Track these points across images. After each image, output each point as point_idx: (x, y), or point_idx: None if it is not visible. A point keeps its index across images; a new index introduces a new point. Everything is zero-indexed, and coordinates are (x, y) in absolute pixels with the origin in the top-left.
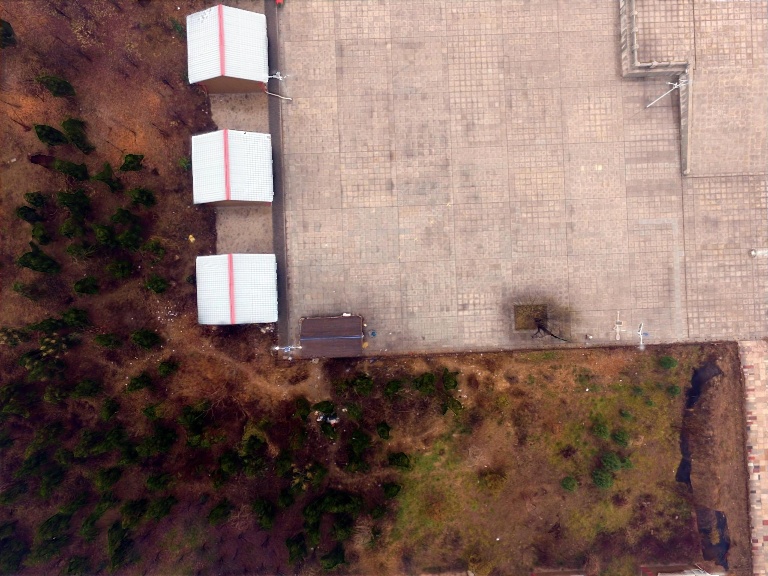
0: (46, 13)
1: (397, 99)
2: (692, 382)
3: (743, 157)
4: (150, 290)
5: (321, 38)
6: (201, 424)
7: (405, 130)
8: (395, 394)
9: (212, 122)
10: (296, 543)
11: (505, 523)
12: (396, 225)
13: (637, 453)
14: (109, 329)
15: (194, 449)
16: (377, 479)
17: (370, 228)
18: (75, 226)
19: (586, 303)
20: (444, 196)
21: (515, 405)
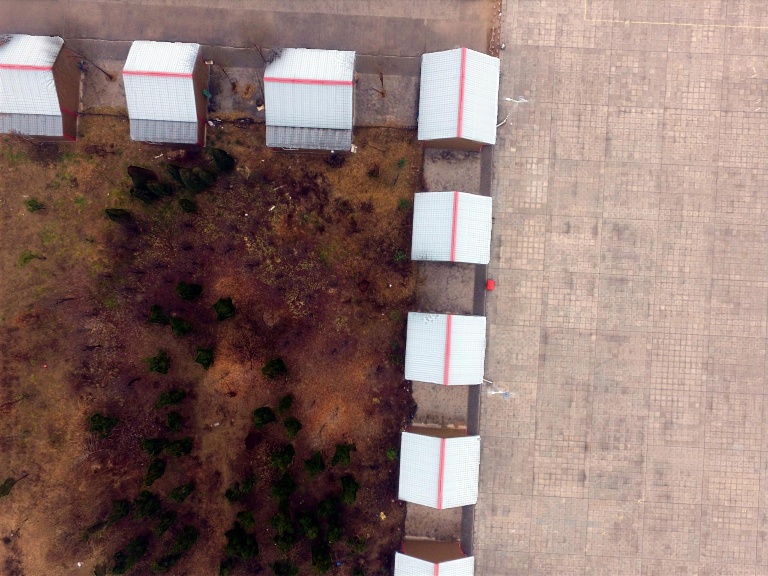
0: (262, 282)
1: (597, 391)
2: None
3: None
4: (339, 566)
5: (527, 324)
6: None
7: (602, 422)
8: None
9: (412, 399)
10: None
11: None
12: (585, 517)
13: None
14: None
15: None
16: None
17: (559, 518)
18: (287, 523)
19: None
20: (636, 492)
21: None
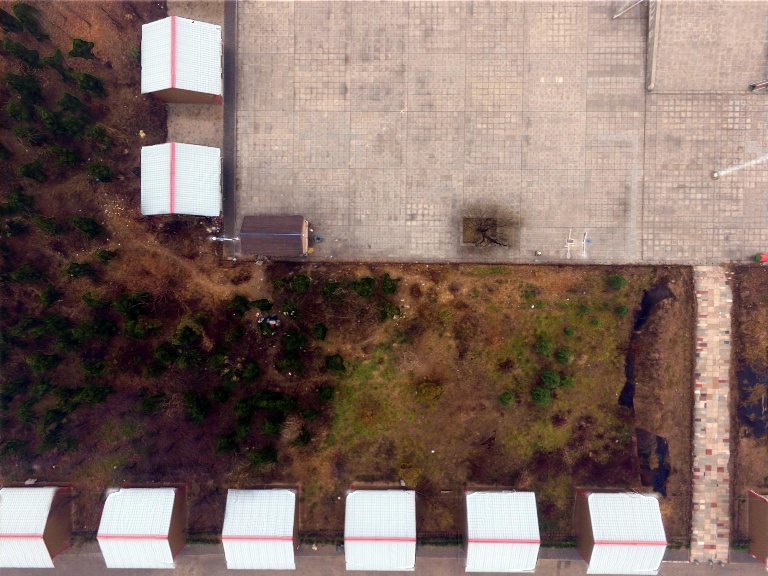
0: None
1: (355, 1)
2: (642, 305)
3: (712, 74)
4: (98, 183)
5: None
6: (139, 313)
7: (362, 33)
8: (332, 294)
9: None
10: (228, 437)
11: (441, 436)
12: (348, 130)
13: (580, 374)
14: (57, 219)
15: (136, 343)
16: (315, 384)
17: (321, 132)
18: (21, 107)
19: (538, 219)
20: (398, 103)
21: (458, 318)
